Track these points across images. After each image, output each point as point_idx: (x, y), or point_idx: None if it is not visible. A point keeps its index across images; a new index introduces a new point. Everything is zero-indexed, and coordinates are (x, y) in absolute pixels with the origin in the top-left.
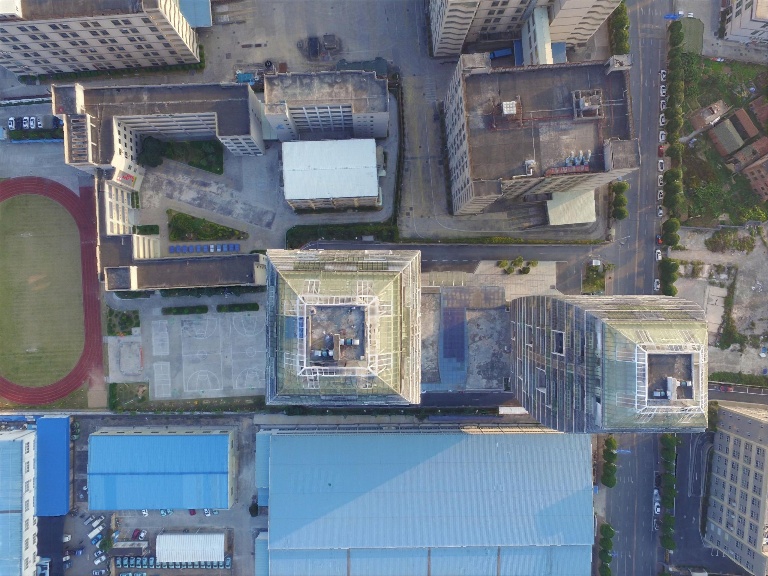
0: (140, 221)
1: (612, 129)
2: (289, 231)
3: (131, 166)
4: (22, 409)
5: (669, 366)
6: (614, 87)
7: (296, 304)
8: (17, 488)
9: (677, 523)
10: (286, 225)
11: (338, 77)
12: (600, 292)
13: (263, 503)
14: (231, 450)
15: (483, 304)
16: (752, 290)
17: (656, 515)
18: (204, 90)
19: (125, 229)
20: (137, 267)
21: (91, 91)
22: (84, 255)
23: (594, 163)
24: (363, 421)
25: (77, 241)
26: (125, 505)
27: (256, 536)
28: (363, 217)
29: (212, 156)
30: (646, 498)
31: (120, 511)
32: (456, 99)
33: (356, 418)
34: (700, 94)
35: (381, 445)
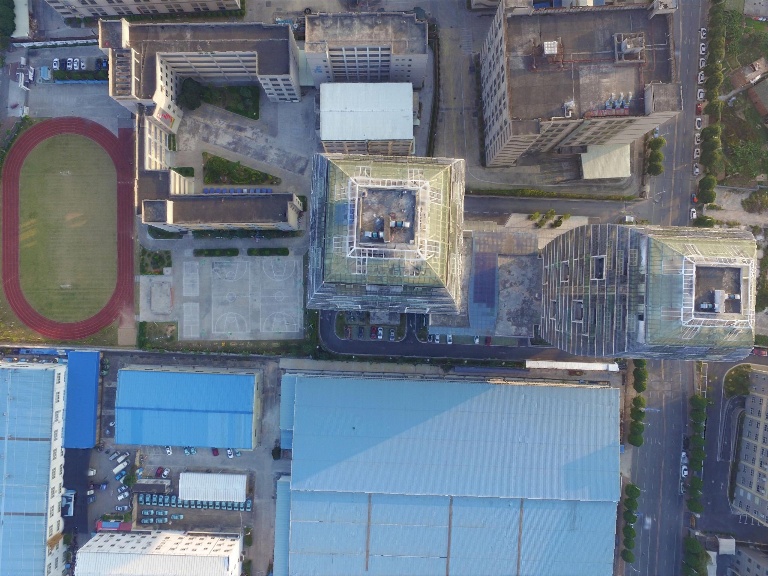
0: (176, 163)
1: (653, 74)
2: None
3: (170, 106)
4: (54, 344)
5: (717, 279)
6: (657, 32)
7: (348, 186)
8: (47, 416)
9: (705, 488)
10: None
11: (378, 19)
12: None
13: (286, 446)
14: (256, 392)
15: (515, 250)
16: None
17: (683, 478)
18: (246, 30)
19: None
20: (173, 202)
21: (136, 28)
22: (120, 195)
23: (634, 107)
24: (388, 370)
25: (114, 181)
26: (151, 440)
27: (277, 480)
28: None
29: (249, 100)
30: (673, 461)
31: (145, 449)
32: (495, 43)
33: (381, 366)
34: (740, 53)
35: (406, 391)
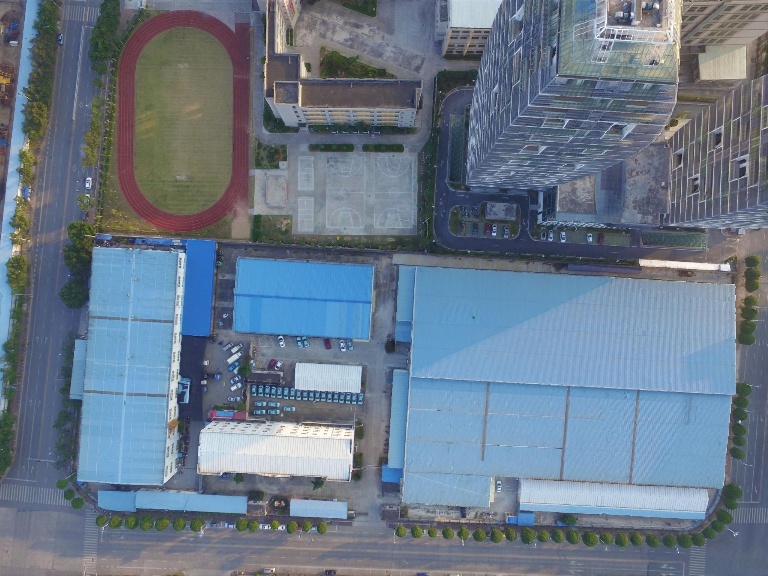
0: None
1: None
2: (441, 72)
3: None
4: (168, 235)
5: None
6: None
7: None
8: (170, 299)
9: None
10: (434, 70)
11: None
12: None
13: (401, 338)
14: None
15: None
16: None
17: None
18: None
19: None
20: (302, 86)
21: None
22: (236, 89)
23: None
24: (500, 267)
25: (230, 75)
26: (269, 328)
27: (389, 374)
28: None
29: None
30: None
31: (257, 341)
32: None
33: (494, 264)
34: None
35: (525, 283)
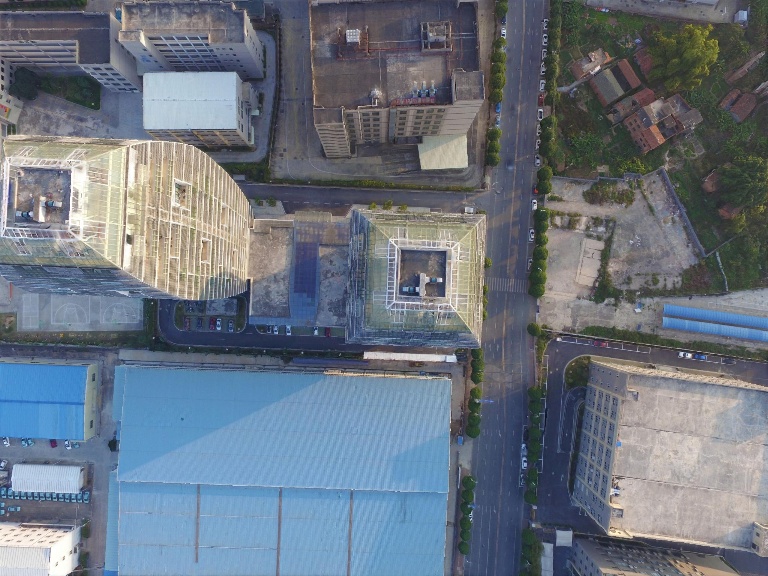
0: None
1: (461, 62)
2: None
3: (2, 95)
4: None
5: (423, 263)
6: (465, 20)
7: (4, 166)
8: None
9: (545, 479)
10: None
11: (197, 7)
12: None
13: None
14: (92, 383)
15: (336, 240)
16: (630, 244)
17: (523, 470)
18: (67, 18)
19: None
20: None
21: None
22: None
23: (442, 96)
24: (228, 361)
25: None
26: None
27: None
28: (237, 157)
29: (86, 90)
30: (514, 452)
31: None
32: None
33: (221, 358)
34: (583, 44)
35: (237, 382)
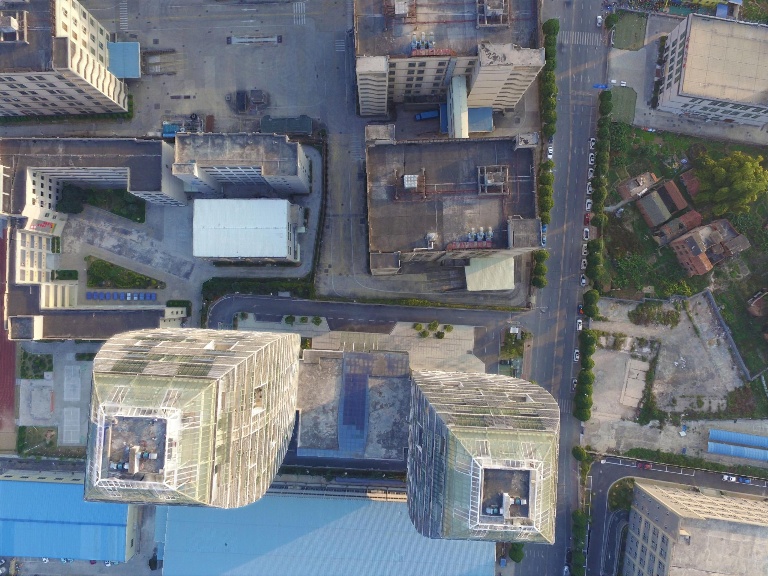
0: (60, 266)
1: (517, 205)
2: (204, 284)
3: (49, 213)
4: None
5: (506, 481)
6: (521, 163)
7: (98, 413)
8: None
9: None
10: (204, 276)
11: (250, 138)
12: (517, 360)
13: (162, 557)
14: None
15: (386, 372)
16: (675, 366)
17: None
18: (119, 145)
19: (41, 274)
20: (43, 316)
21: (8, 141)
22: (3, 296)
23: (497, 239)
24: None
25: None
26: (22, 552)
27: None
28: (281, 272)
29: (132, 206)
30: (556, 574)
31: None
32: None
33: None
34: (630, 163)
35: (281, 507)
